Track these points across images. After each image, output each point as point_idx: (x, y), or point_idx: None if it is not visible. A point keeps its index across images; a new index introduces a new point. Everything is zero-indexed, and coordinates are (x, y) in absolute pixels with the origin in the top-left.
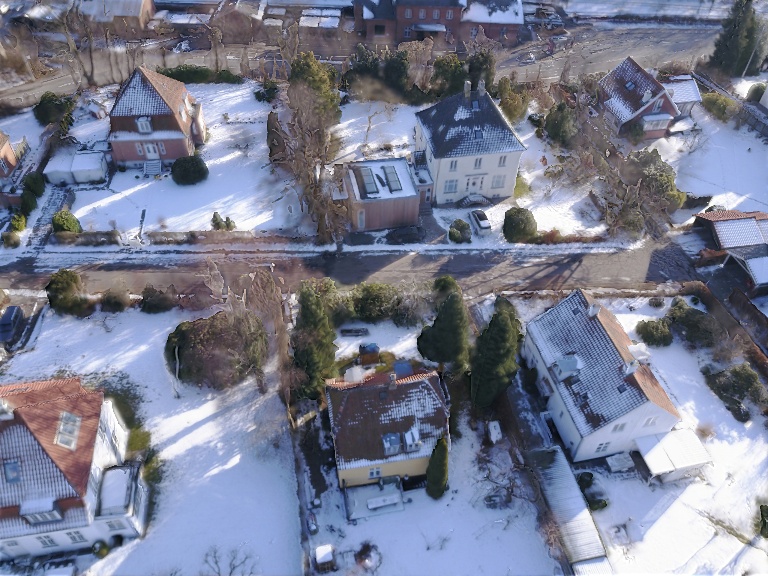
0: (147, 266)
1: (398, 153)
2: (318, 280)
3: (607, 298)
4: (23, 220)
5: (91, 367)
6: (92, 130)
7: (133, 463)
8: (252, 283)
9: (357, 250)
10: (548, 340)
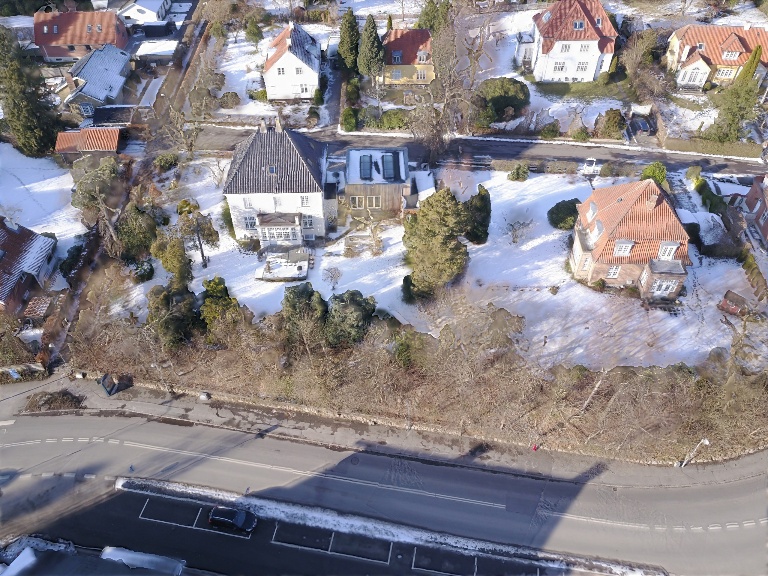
0: (571, 160)
1: (339, 248)
2: None
3: (239, 121)
4: None
5: (573, 105)
6: (720, 280)
7: (528, 70)
8: None
9: None
10: (313, 63)
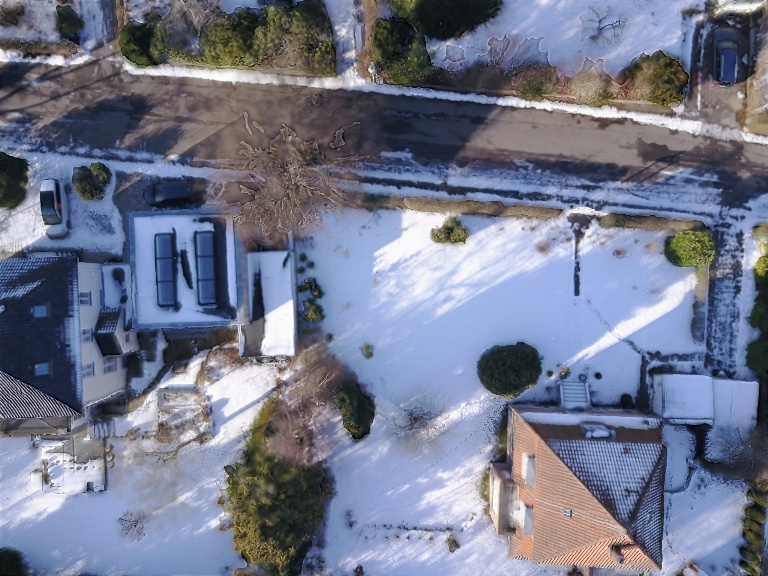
0: (558, 169)
1: (150, 417)
2: (311, 69)
3: None
4: (761, 272)
5: None
6: (700, 526)
7: None
8: (399, 23)
9: (253, 173)
10: None
